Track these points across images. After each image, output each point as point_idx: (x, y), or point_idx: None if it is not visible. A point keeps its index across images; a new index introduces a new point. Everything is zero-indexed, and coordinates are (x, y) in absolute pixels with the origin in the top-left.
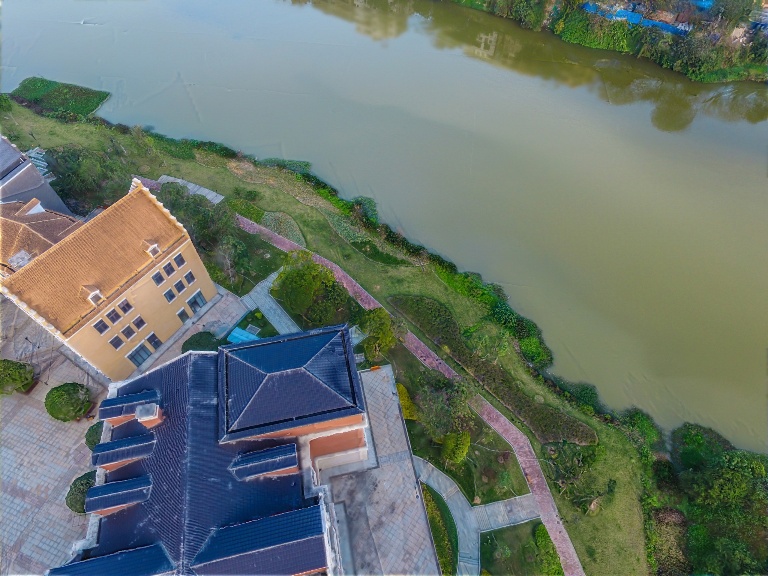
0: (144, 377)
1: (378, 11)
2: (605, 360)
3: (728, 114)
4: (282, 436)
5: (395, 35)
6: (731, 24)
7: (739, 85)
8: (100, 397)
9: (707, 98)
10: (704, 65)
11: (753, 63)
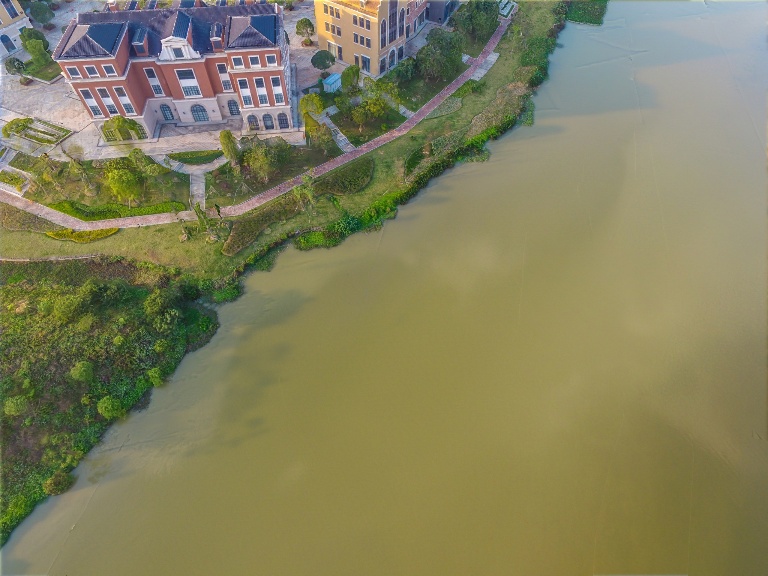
0: None
1: None
2: (291, 286)
3: None
4: None
5: None
6: None
7: None
8: (314, 47)
9: None
10: None
11: None
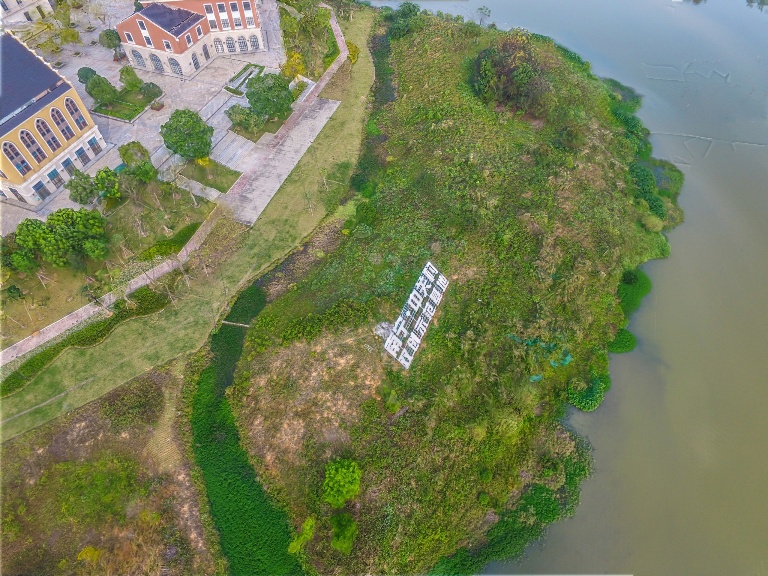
0: None
1: None
2: None
3: None
4: None
5: None
6: None
7: None
8: None
9: None
10: None
11: None
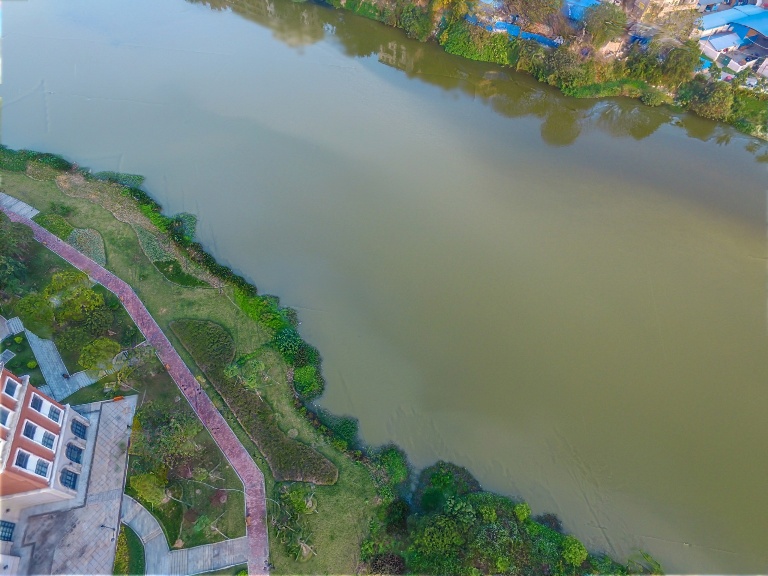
0: None
1: (268, 19)
2: (378, 392)
3: (617, 129)
4: None
5: (277, 44)
6: (597, 39)
7: (614, 101)
8: None
9: (586, 113)
10: (575, 80)
11: (629, 78)
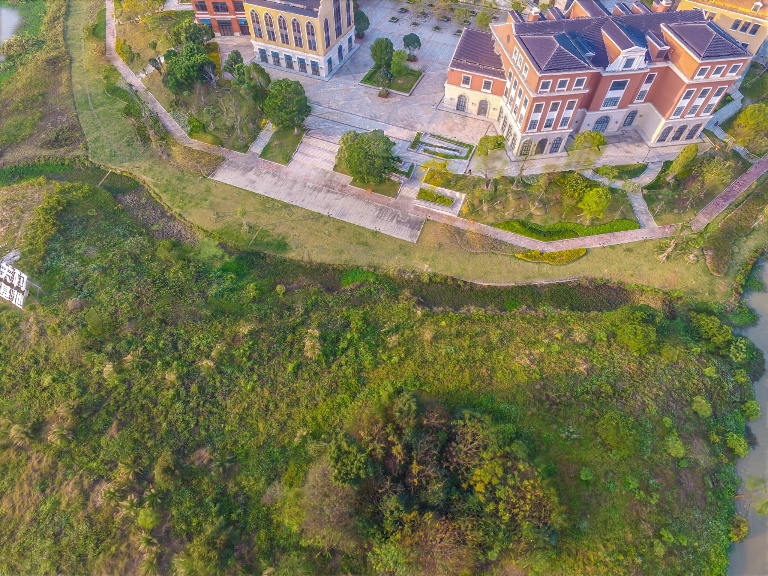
0: None
1: None
2: None
3: None
4: (669, 51)
5: None
6: None
7: None
8: None
9: None
10: None
11: None
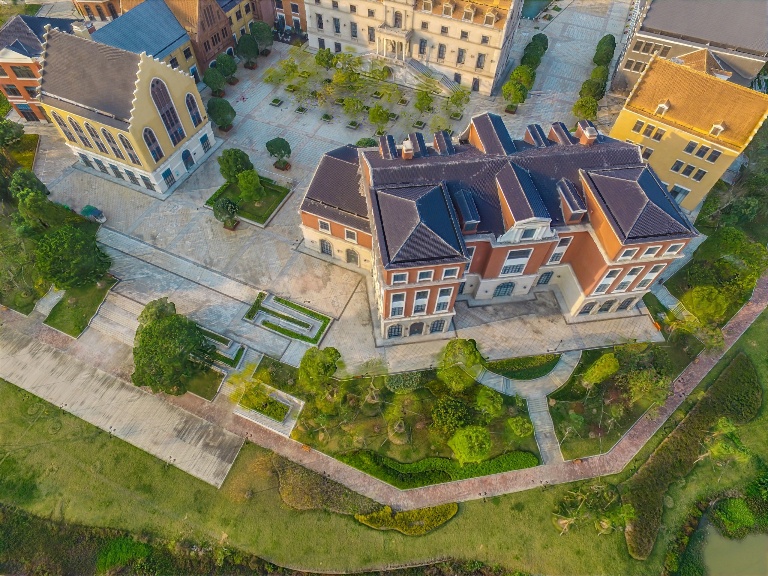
0: (611, 138)
1: None
2: None
3: None
4: (589, 210)
5: None
6: None
7: None
8: None
9: None
10: None
11: None
